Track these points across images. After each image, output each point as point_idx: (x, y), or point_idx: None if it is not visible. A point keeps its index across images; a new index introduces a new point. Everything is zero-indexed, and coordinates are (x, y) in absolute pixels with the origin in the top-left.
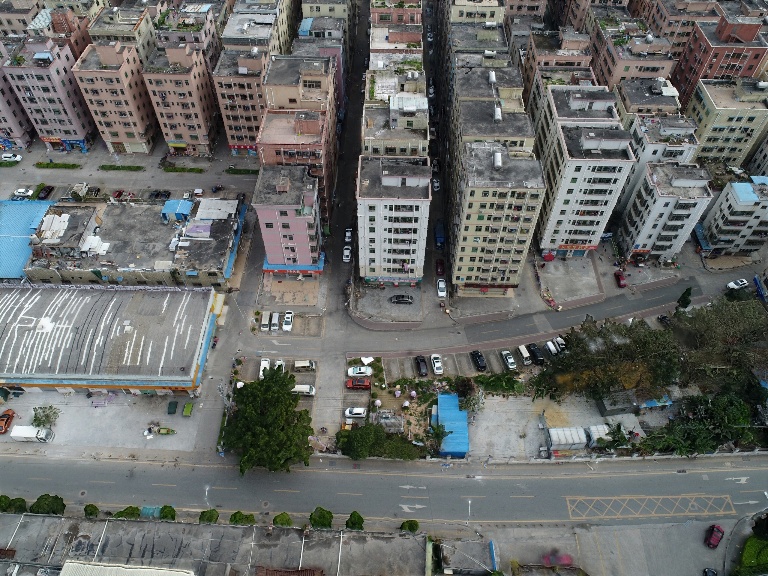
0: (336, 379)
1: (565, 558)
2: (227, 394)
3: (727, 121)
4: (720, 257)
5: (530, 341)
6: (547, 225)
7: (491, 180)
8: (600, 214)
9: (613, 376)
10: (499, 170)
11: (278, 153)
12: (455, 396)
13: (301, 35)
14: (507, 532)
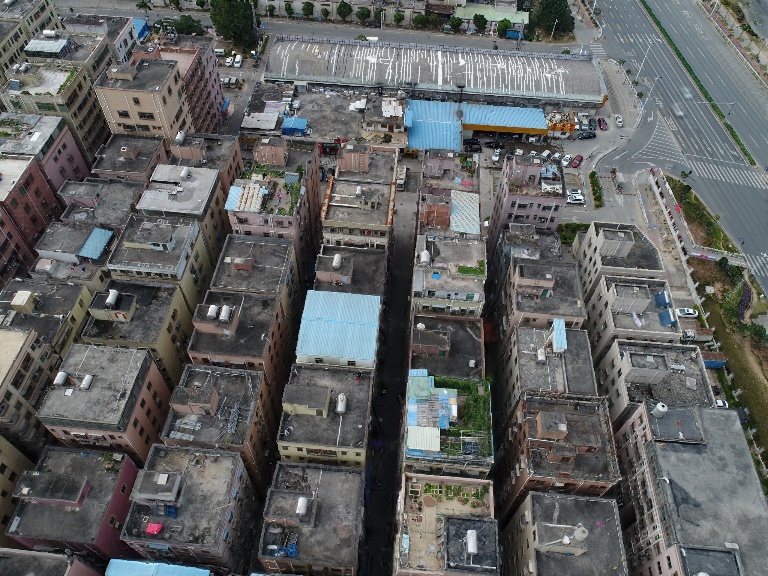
0: None
1: (109, 1)
2: None
3: None
4: None
5: None
6: None
7: None
8: None
9: None
10: None
11: None
12: None
13: None
14: (130, 8)
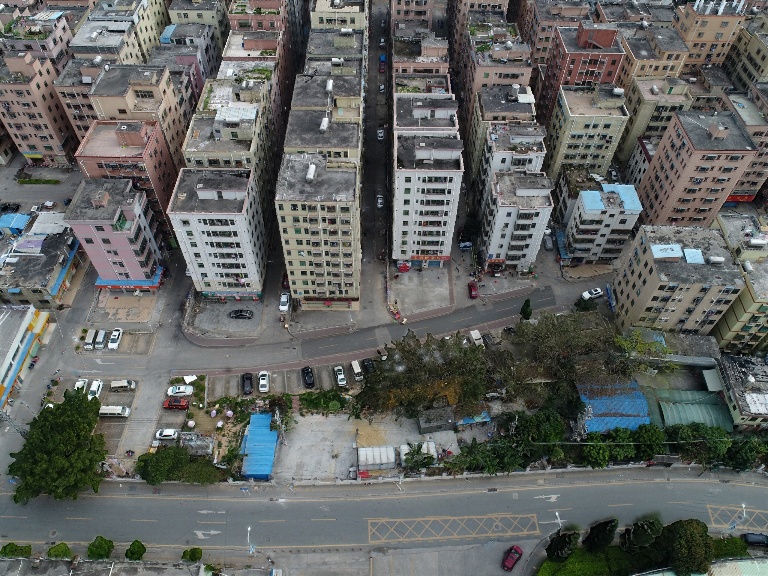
0: (155, 399)
1: None
2: (34, 417)
3: (584, 128)
4: (581, 265)
5: (367, 356)
6: (393, 236)
7: (300, 193)
8: (444, 224)
9: (419, 394)
10: (311, 183)
11: (100, 166)
12: (269, 416)
13: (163, 42)
14: (300, 558)
